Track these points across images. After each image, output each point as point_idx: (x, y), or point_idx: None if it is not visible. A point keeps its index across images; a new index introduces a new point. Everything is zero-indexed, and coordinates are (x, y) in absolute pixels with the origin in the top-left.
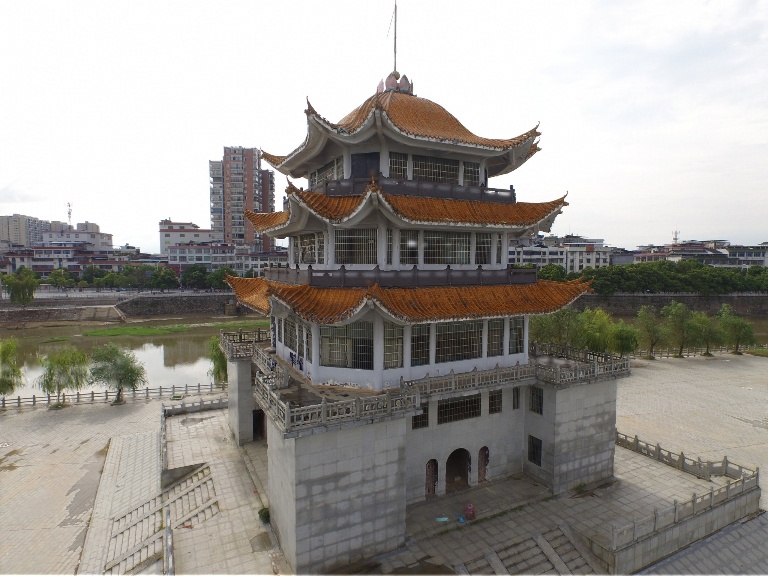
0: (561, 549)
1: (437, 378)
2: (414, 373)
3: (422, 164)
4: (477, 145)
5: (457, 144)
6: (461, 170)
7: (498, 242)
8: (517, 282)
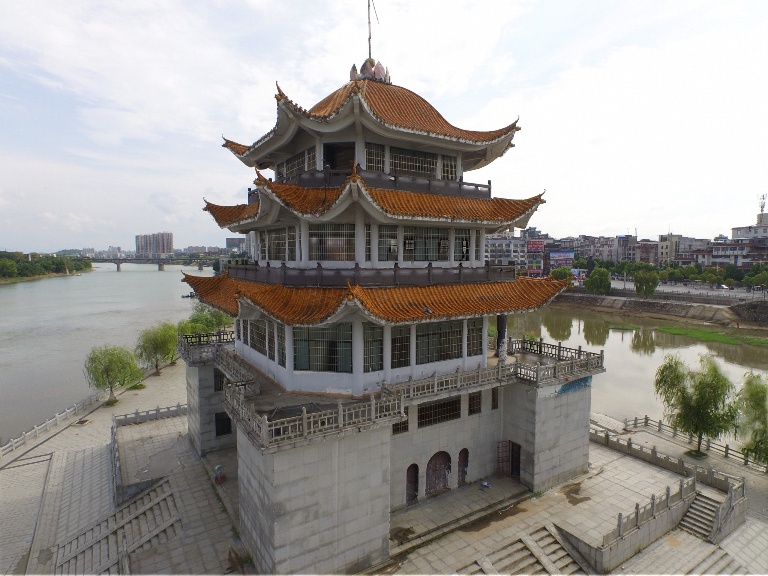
0: (163, 536)
1: (223, 353)
2: (244, 349)
3: (289, 167)
4: (262, 140)
5: (255, 147)
6: (306, 160)
7: (300, 235)
8: (270, 282)
